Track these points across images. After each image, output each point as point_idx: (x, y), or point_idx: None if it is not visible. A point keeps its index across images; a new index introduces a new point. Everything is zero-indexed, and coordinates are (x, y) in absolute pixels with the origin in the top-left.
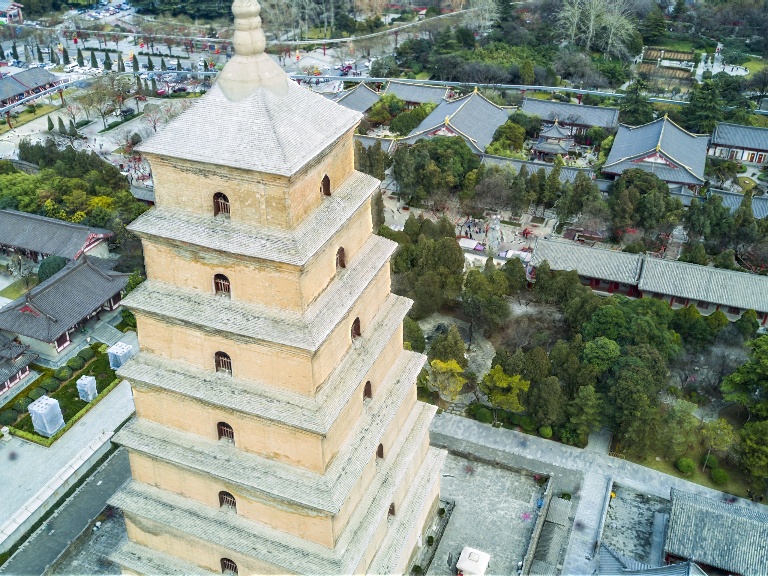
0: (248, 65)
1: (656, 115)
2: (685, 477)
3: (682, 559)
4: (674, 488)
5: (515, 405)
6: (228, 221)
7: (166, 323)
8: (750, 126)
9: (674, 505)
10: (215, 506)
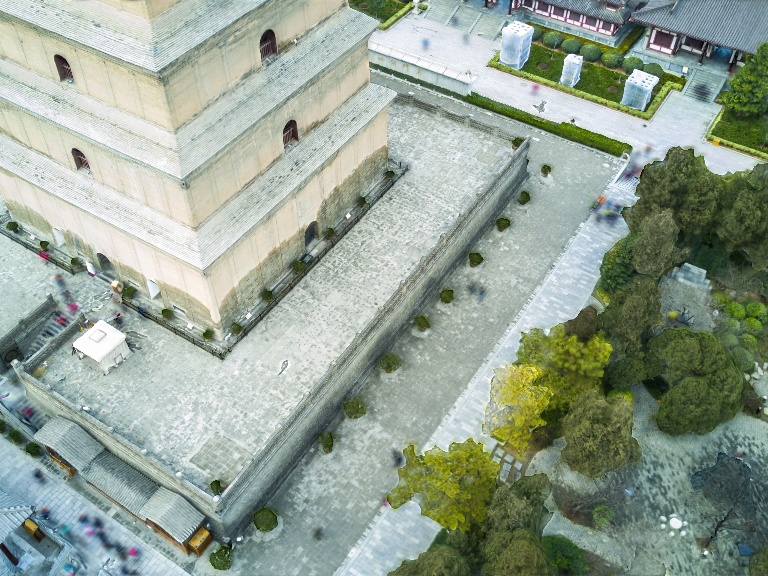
0: None
1: None
2: None
3: None
4: None
5: (403, 489)
6: None
7: None
8: None
9: None
10: None
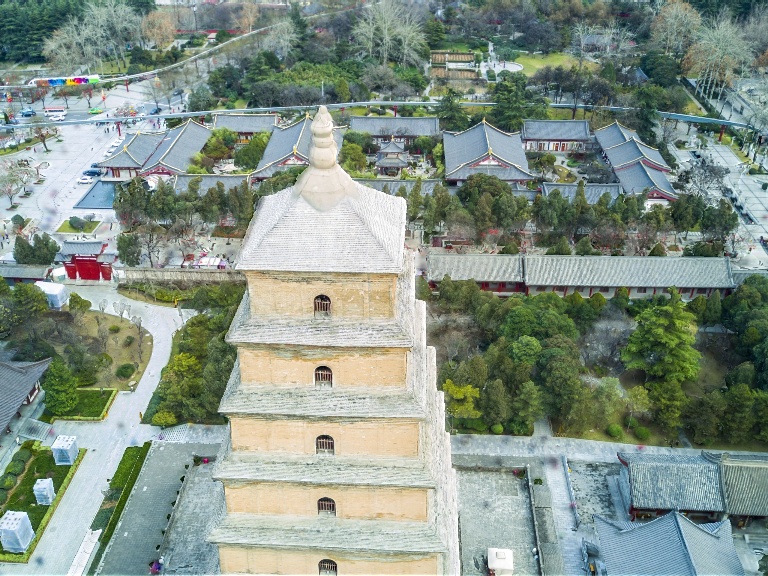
0: (332, 177)
1: (470, 119)
2: (617, 440)
3: (643, 510)
4: (620, 453)
5: (473, 412)
6: (329, 318)
7: (265, 420)
8: (550, 120)
9: (632, 467)
10: (313, 575)
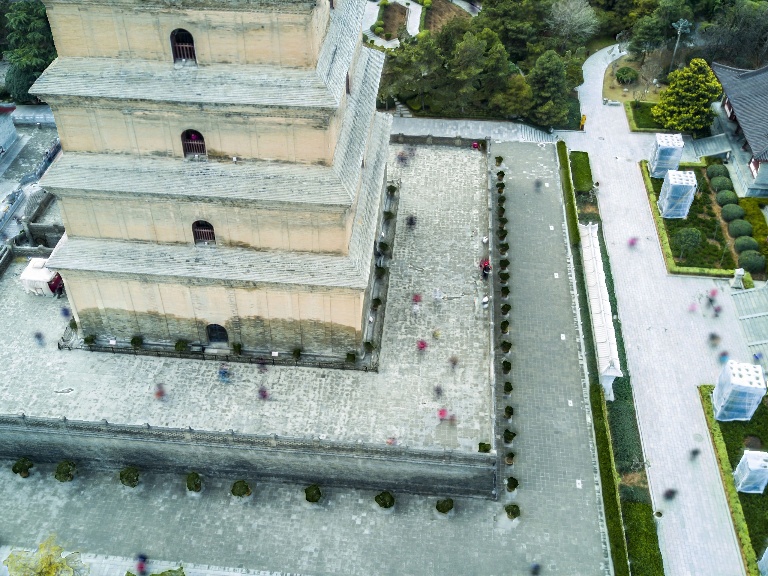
0: None
1: None
2: None
3: None
4: None
5: None
6: None
7: None
8: None
9: None
10: None
